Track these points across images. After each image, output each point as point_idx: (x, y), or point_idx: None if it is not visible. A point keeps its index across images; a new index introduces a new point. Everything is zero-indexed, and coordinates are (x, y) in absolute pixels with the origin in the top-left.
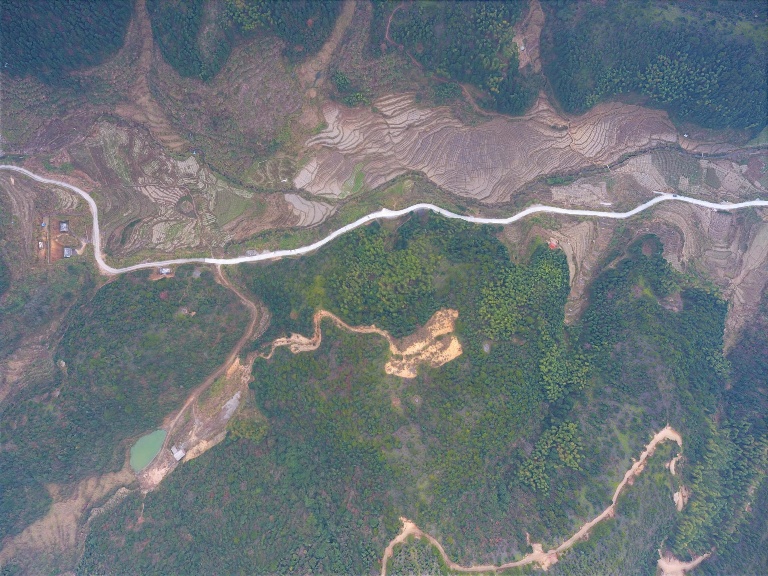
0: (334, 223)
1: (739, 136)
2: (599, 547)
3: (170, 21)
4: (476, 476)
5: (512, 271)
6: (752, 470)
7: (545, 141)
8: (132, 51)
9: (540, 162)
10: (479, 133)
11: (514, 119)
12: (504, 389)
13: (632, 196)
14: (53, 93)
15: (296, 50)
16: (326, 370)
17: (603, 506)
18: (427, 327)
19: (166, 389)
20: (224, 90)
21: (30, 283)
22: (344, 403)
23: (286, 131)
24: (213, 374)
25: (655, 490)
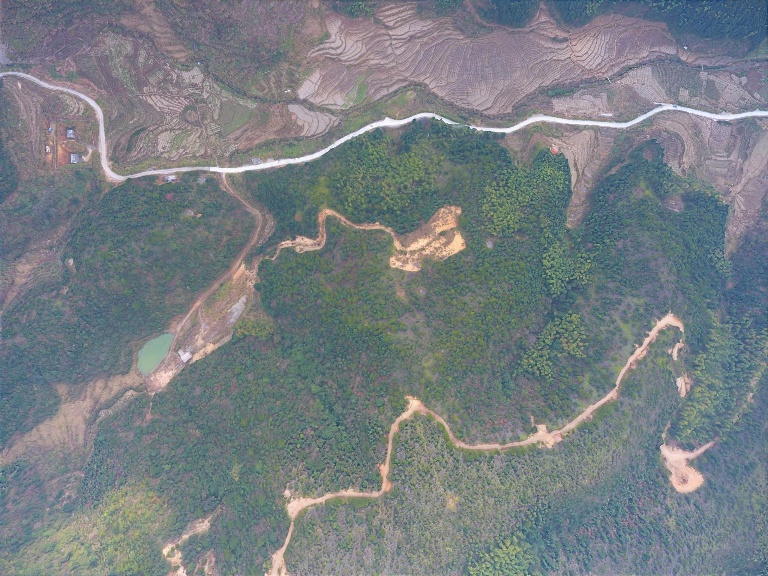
0: (337, 132)
1: (738, 47)
2: (603, 426)
3: None
4: (480, 360)
5: (514, 173)
6: (754, 362)
7: (546, 53)
8: None
9: (541, 74)
10: (480, 45)
11: (515, 31)
12: (507, 277)
13: (632, 107)
14: (59, 2)
15: None
16: (331, 265)
17: (606, 389)
18: (431, 223)
19: (173, 289)
20: None
21: (38, 185)
22: (349, 292)
23: (289, 40)
24: (219, 279)
25: (658, 373)
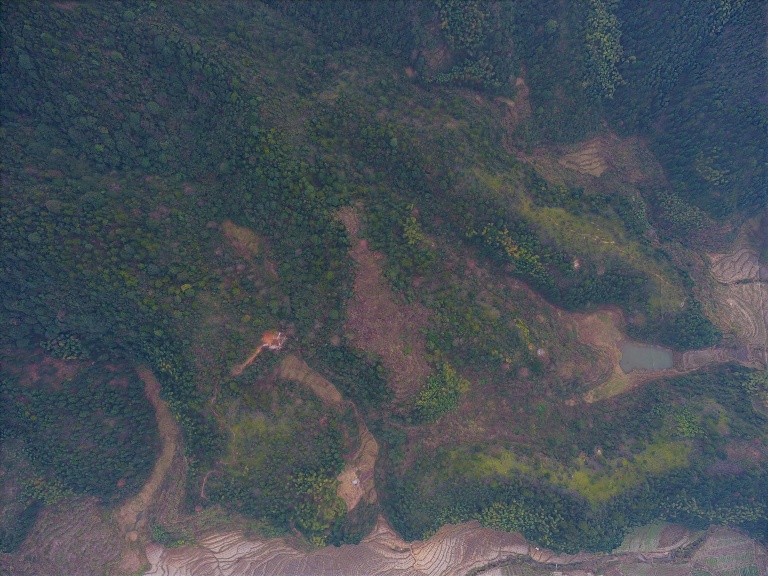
0: None
1: None
2: None
3: None
4: None
5: None
6: None
7: (387, 563)
8: None
9: None
10: (316, 557)
11: None
12: None
13: None
14: None
15: (112, 499)
16: None
17: None
18: None
19: None
20: (32, 554)
21: None
22: None
23: None
24: None
25: None
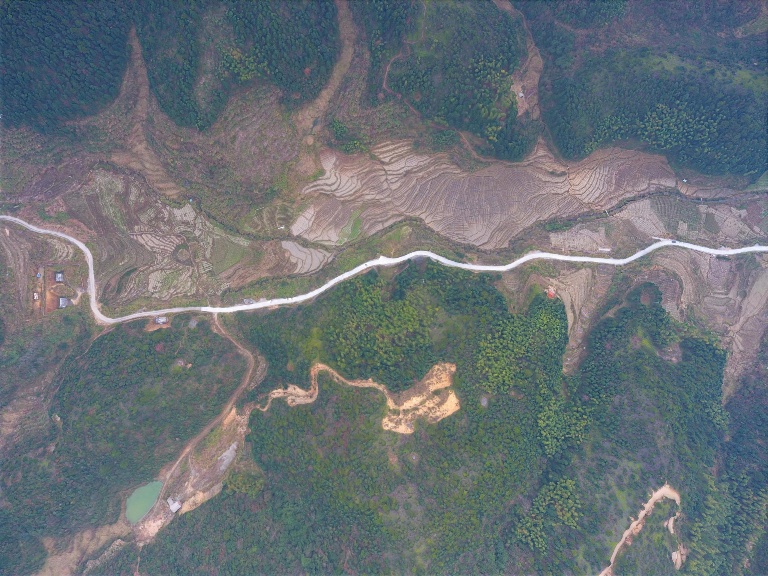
0: (331, 271)
1: (738, 181)
2: None
3: (166, 72)
4: (473, 537)
5: (510, 322)
6: (751, 526)
7: (543, 187)
8: (128, 100)
9: (538, 208)
10: (477, 179)
11: (512, 165)
12: (502, 447)
13: (631, 242)
14: (48, 142)
15: (293, 98)
16: (323, 425)
17: (601, 567)
18: (424, 381)
19: (162, 442)
20: (221, 139)
21: (25, 336)
22: (341, 461)
23: (283, 179)
24: (209, 424)
25: (653, 551)
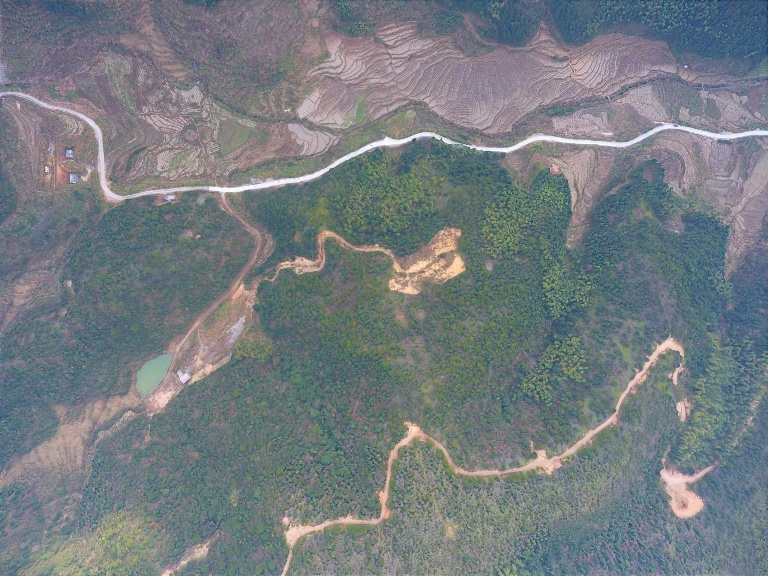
0: (337, 152)
1: (739, 66)
2: (603, 452)
3: None
4: (480, 385)
5: (514, 194)
6: (754, 385)
7: (546, 72)
8: None
9: (541, 93)
10: (480, 64)
11: (515, 50)
12: (507, 301)
13: (633, 126)
14: (58, 21)
15: None
16: (330, 287)
17: (606, 414)
18: (430, 246)
19: (172, 310)
20: (227, 17)
21: (36, 206)
22: (348, 316)
23: (289, 60)
24: (218, 300)
25: (658, 398)
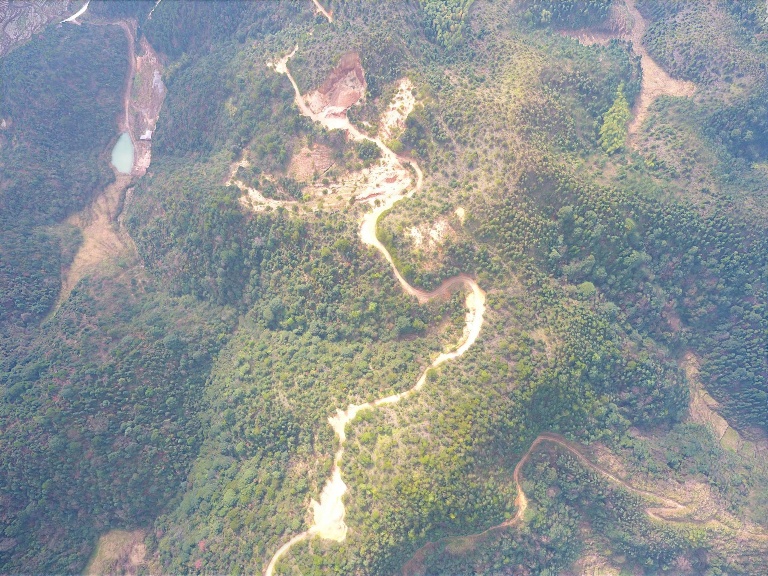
0: None
1: None
2: None
3: None
4: None
5: None
6: None
7: None
8: None
9: None
10: None
11: None
12: None
13: None
14: None
15: None
16: None
17: None
18: None
19: (96, 91)
20: None
21: None
22: None
23: None
24: (128, 78)
25: None
